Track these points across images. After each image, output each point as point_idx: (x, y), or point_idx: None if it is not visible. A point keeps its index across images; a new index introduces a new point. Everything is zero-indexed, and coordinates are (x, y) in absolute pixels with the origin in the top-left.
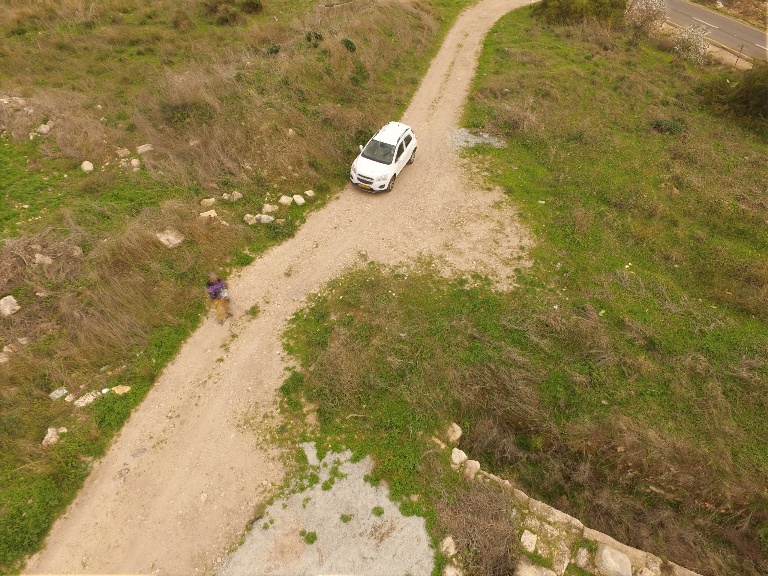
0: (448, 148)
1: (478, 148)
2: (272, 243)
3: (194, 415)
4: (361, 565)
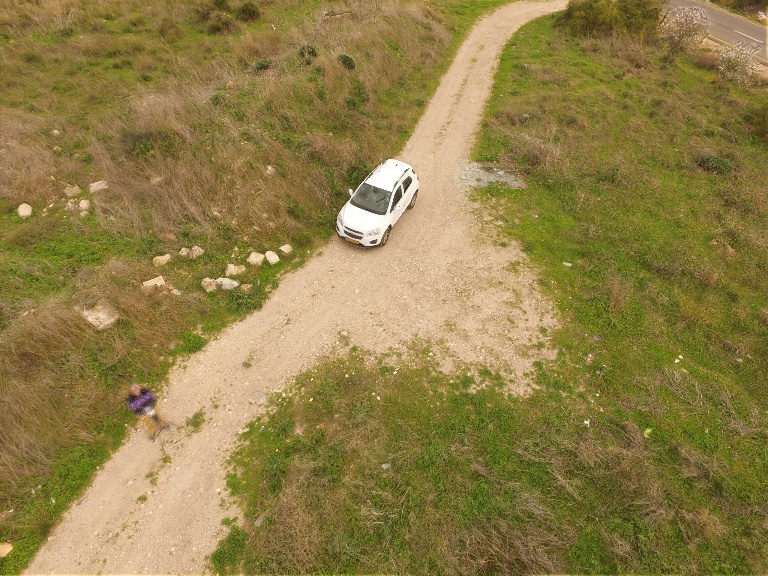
0: (456, 188)
1: (491, 189)
2: (233, 317)
3: None
4: None
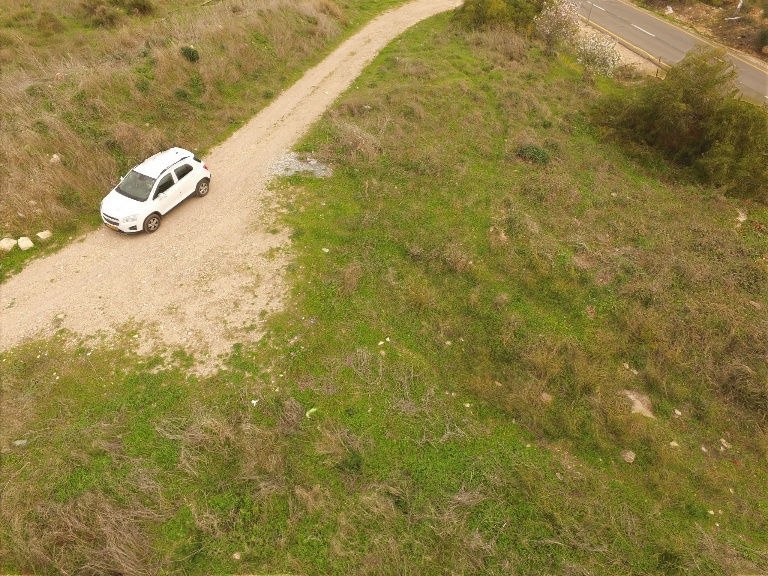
0: (259, 177)
1: (292, 178)
2: None
3: None
4: None
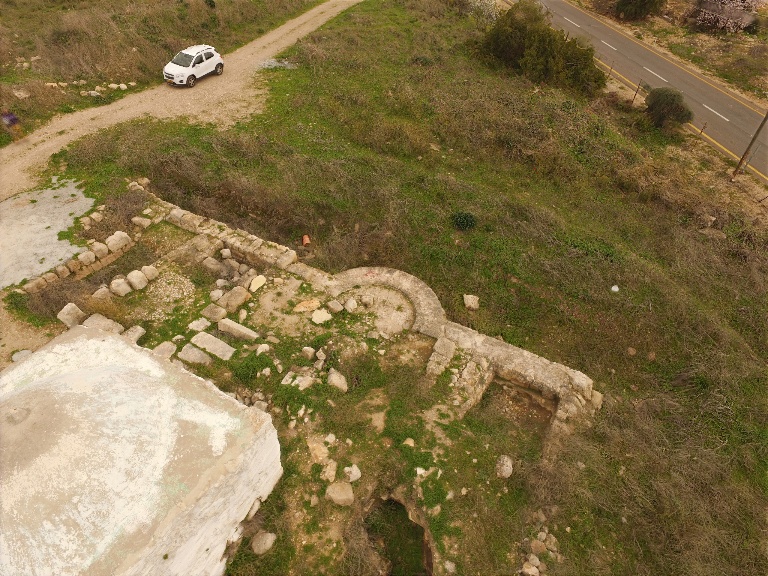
0: (253, 68)
1: (272, 68)
2: (93, 106)
3: (2, 166)
4: (52, 209)
